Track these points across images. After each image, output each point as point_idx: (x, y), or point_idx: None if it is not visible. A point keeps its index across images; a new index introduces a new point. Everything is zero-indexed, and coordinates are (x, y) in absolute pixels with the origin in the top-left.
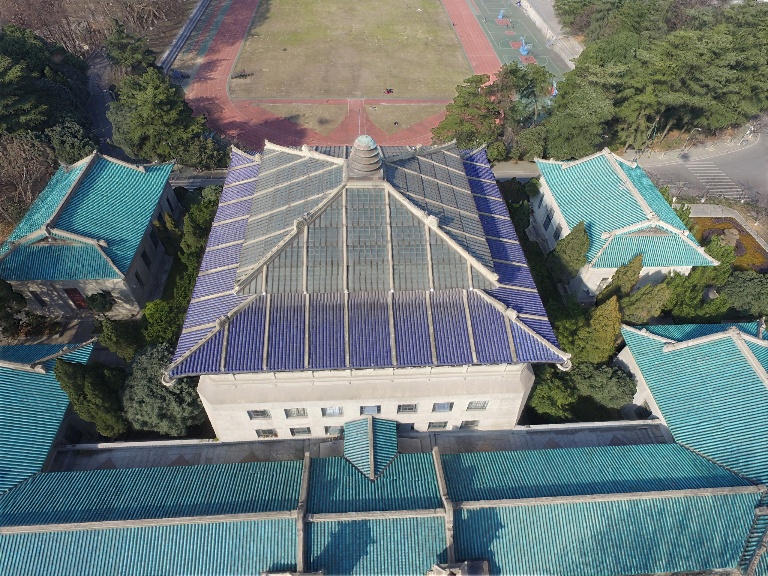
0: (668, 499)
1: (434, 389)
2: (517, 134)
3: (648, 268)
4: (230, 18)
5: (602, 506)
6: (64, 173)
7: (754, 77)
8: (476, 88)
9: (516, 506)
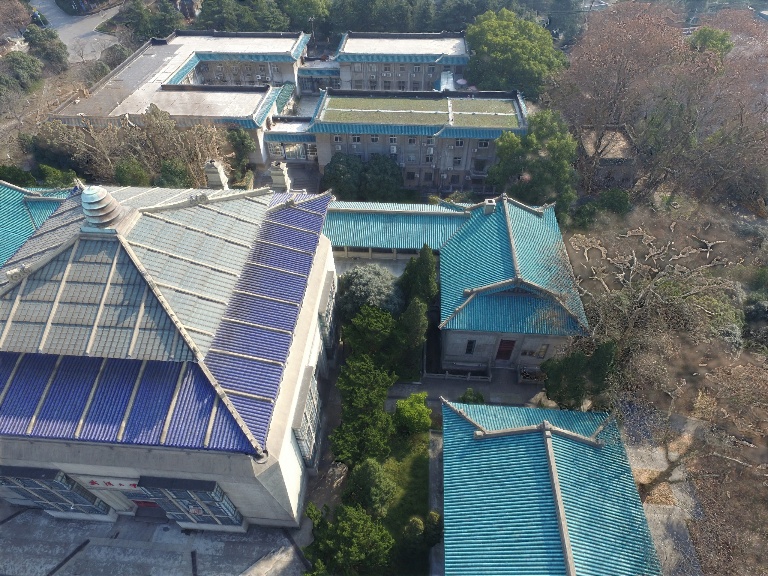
0: None
1: None
2: None
3: None
4: None
5: None
6: None
7: None
8: None
9: None
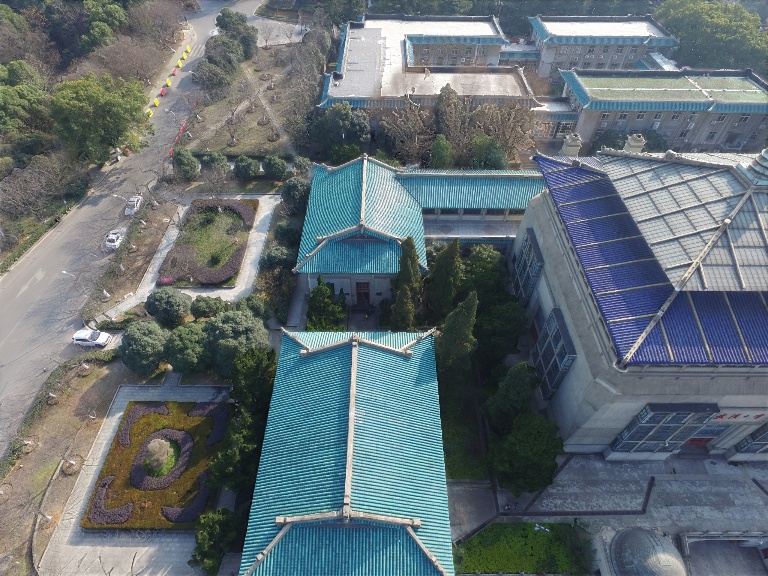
0: None
1: None
2: None
3: None
4: None
5: None
6: None
7: None
8: None
9: None
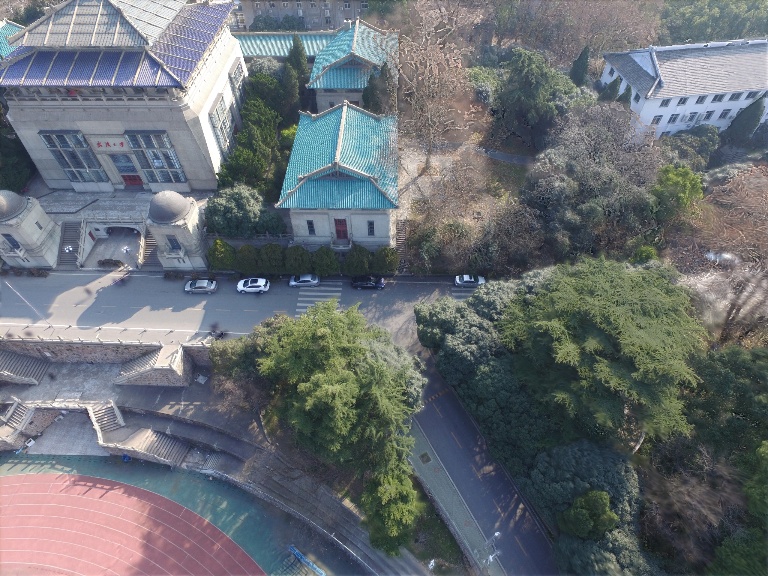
0: None
1: None
2: None
3: None
4: None
5: None
6: (380, 183)
7: None
8: None
9: None
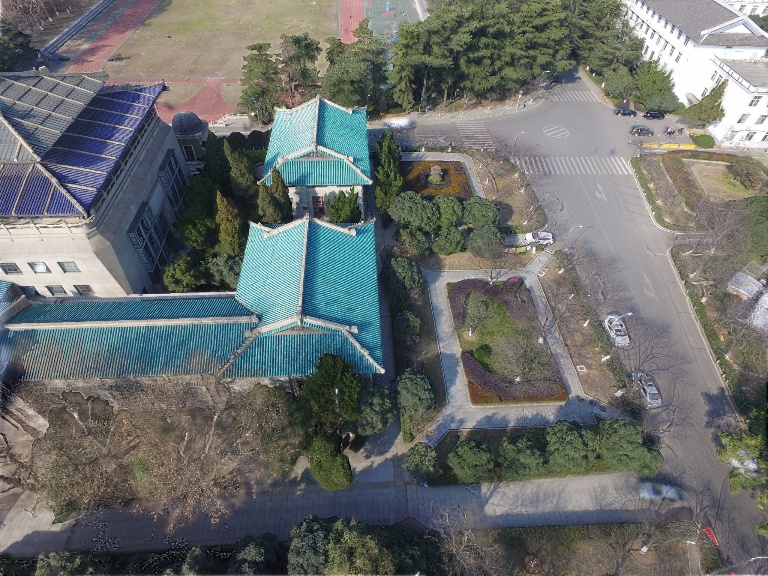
0: (179, 326)
1: (18, 248)
2: (304, 97)
3: (323, 189)
4: (130, 11)
5: (124, 330)
6: None
7: (513, 45)
8: (262, 55)
9: (55, 329)
